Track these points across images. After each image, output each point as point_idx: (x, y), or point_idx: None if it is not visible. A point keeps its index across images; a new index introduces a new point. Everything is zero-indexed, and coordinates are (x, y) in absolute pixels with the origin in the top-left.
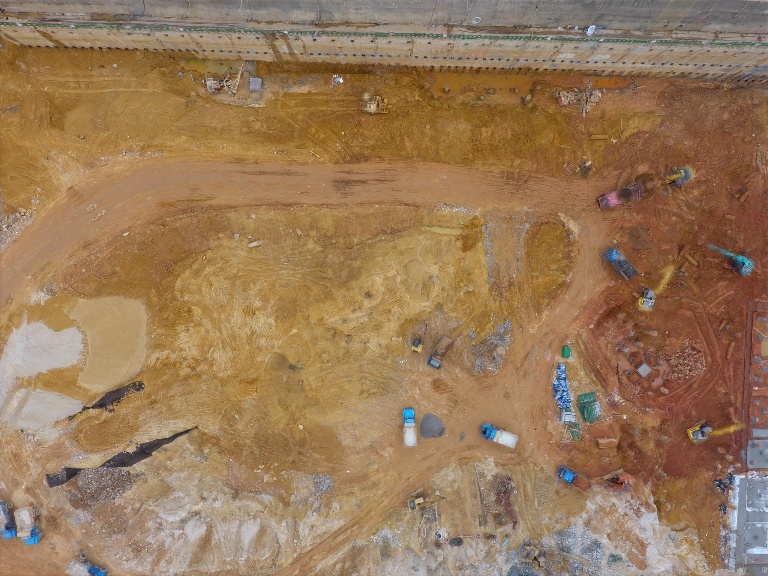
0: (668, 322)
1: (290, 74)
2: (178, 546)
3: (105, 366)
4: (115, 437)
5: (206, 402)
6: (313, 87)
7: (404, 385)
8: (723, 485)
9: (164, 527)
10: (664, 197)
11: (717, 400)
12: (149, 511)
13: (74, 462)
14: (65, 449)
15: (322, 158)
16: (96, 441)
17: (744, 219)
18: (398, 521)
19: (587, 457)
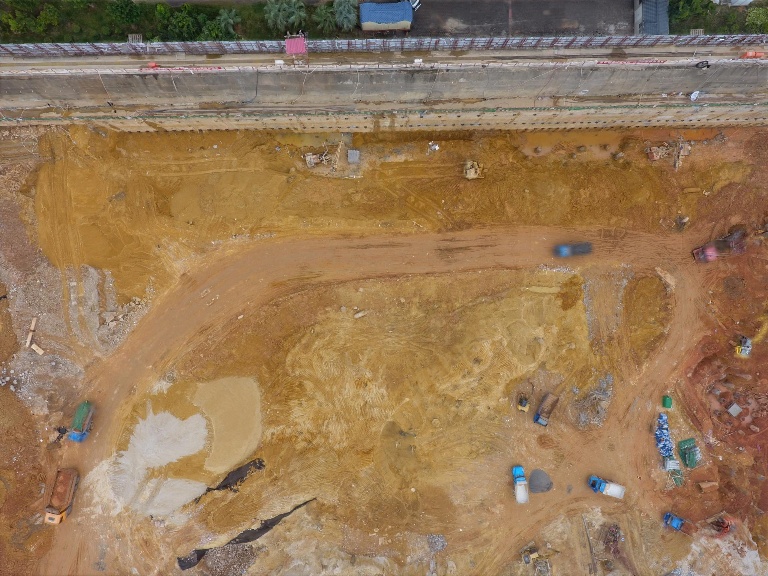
0: (759, 364)
1: (386, 144)
2: None
3: (228, 448)
4: (241, 516)
5: (325, 475)
6: (409, 155)
7: (511, 443)
8: None
9: None
10: (757, 247)
11: None
12: None
13: (204, 544)
14: (195, 532)
15: (425, 228)
16: (224, 522)
17: None
18: (513, 575)
19: (690, 502)
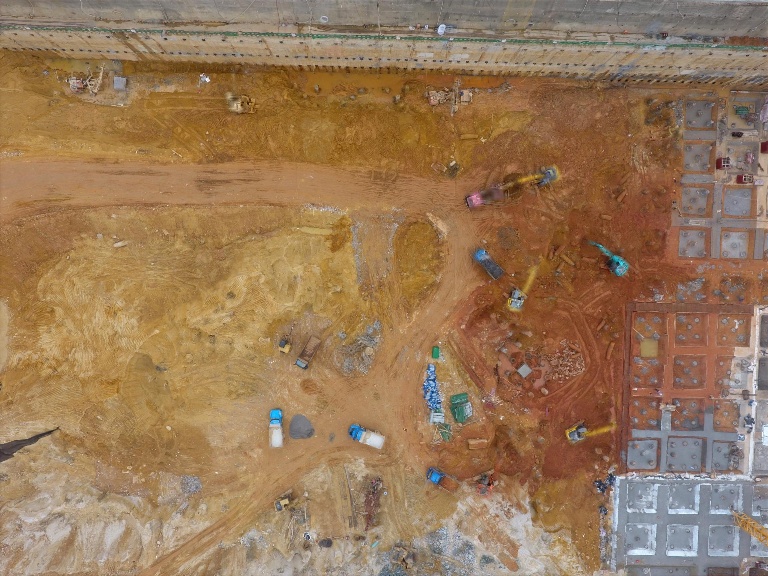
0: (545, 322)
1: (156, 73)
2: (38, 548)
3: None
4: None
5: (66, 403)
6: (180, 86)
7: (273, 386)
8: (603, 486)
9: (23, 529)
10: (533, 197)
11: (595, 401)
12: (9, 513)
13: None
14: None
15: (185, 158)
16: None
17: (621, 219)
18: (266, 522)
19: (458, 458)
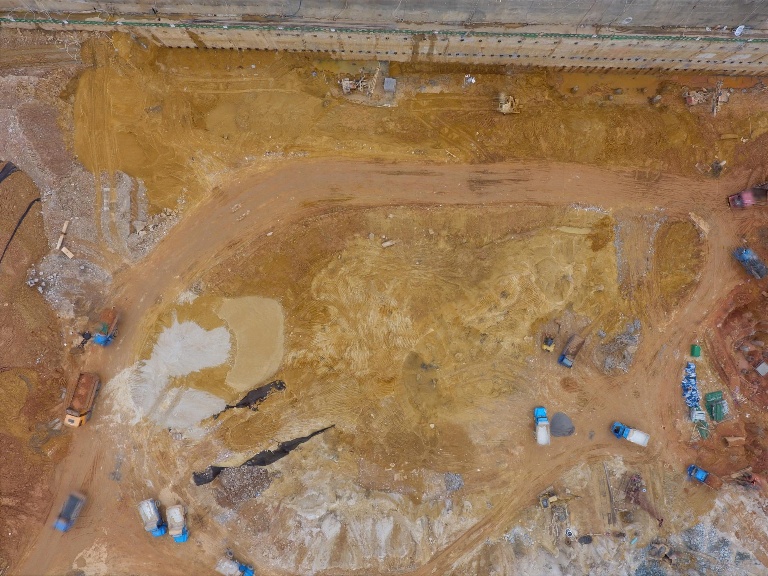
0: None
1: (422, 74)
2: (317, 544)
3: (249, 365)
4: (258, 436)
5: (345, 401)
6: (445, 87)
7: (534, 384)
8: None
9: (304, 525)
10: None
11: None
12: (288, 509)
13: (220, 460)
14: (212, 448)
15: (458, 158)
16: (241, 440)
17: None
18: (529, 519)
19: (715, 455)
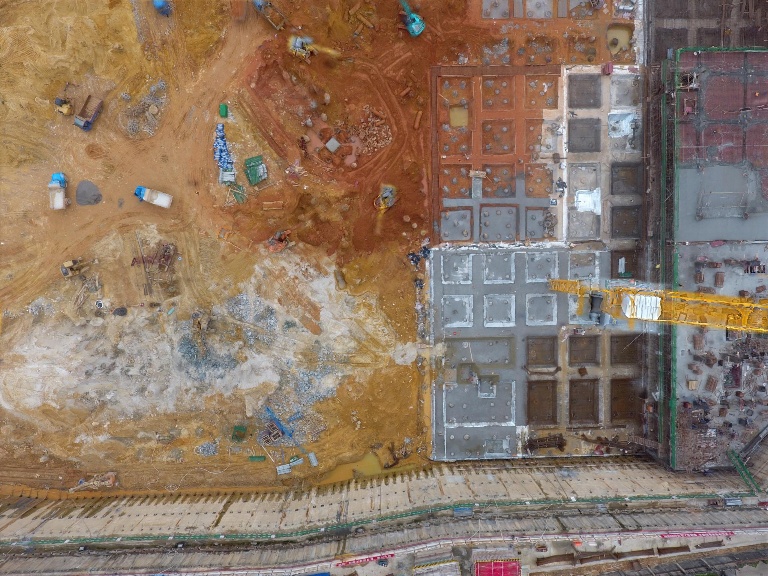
0: (346, 88)
1: None
2: None
3: None
4: None
5: None
6: None
7: (58, 152)
8: (416, 258)
9: None
10: None
11: (401, 168)
12: None
13: None
14: None
15: None
16: None
17: None
18: (54, 290)
19: (253, 220)
